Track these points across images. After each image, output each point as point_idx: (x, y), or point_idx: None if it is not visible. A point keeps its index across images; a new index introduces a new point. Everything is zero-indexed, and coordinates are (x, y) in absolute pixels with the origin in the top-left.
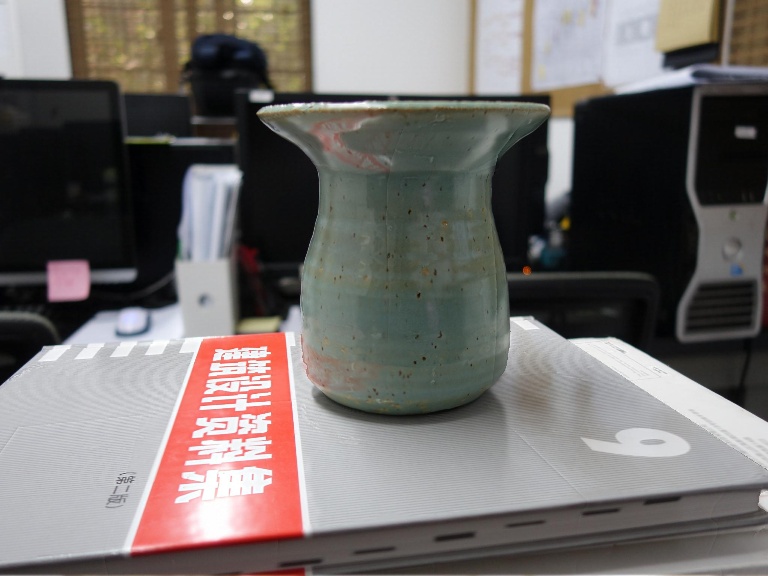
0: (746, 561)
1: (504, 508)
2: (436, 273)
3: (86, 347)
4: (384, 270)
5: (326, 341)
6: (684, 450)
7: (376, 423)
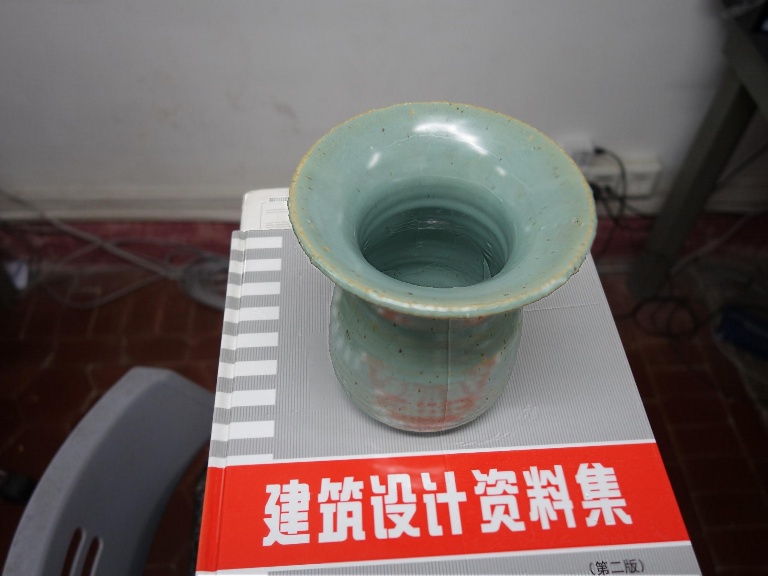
0: None
1: None
2: None
3: None
4: None
5: None
6: None
7: None
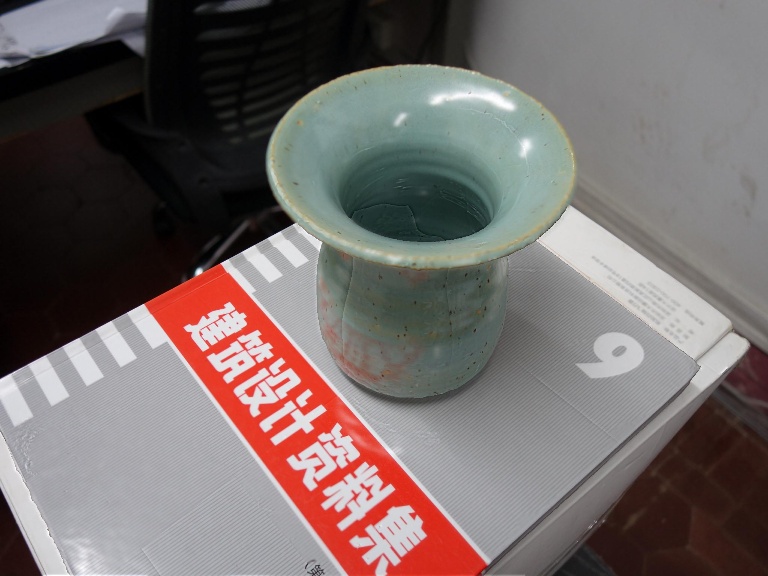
0: (676, 410)
1: (582, 477)
2: (486, 309)
3: (32, 373)
4: (448, 324)
5: (388, 372)
6: (641, 354)
7: (431, 404)
